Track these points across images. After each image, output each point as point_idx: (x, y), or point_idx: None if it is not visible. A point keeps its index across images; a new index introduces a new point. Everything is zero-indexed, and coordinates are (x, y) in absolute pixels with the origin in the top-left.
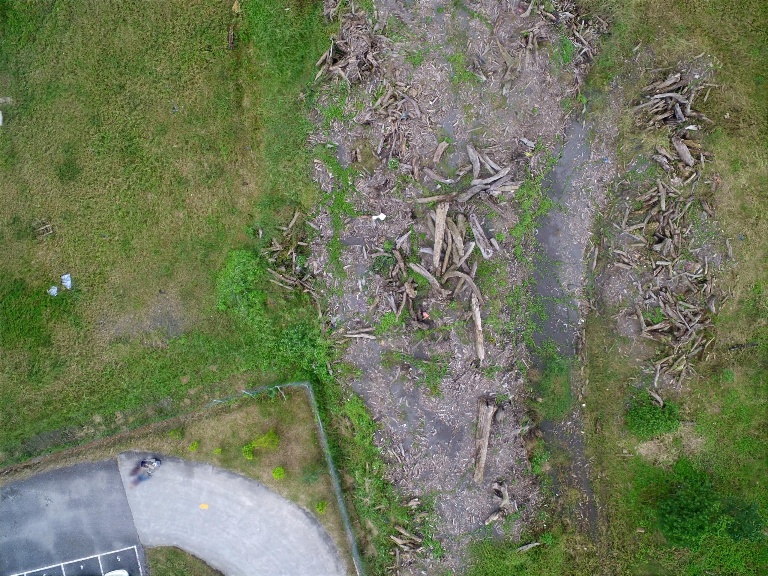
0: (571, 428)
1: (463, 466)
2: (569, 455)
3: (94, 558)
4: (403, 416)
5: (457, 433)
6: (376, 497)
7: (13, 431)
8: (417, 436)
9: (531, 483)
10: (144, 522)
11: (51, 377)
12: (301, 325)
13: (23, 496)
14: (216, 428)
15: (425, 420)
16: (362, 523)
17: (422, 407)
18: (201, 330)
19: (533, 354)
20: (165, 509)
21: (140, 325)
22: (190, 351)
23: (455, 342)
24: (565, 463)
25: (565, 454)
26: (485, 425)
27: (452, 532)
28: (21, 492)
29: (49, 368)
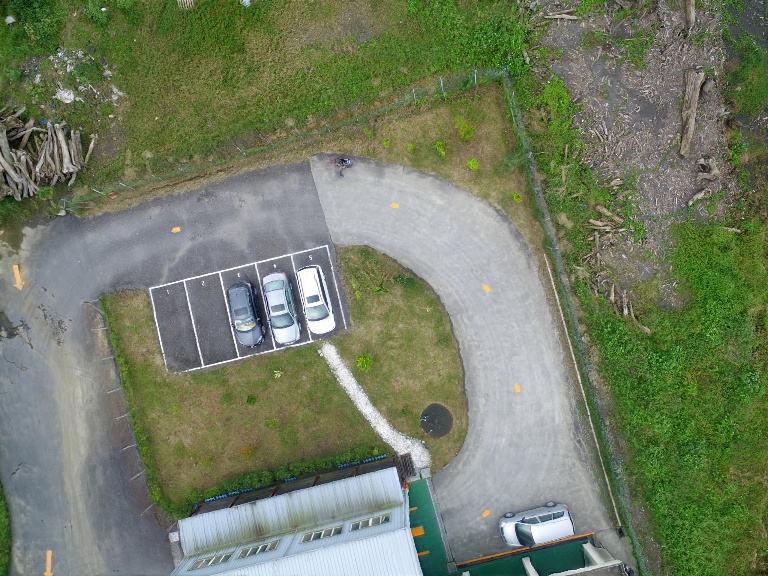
0: (767, 123)
1: (668, 142)
2: (766, 150)
3: (287, 257)
4: (605, 95)
5: (661, 110)
6: (573, 184)
7: (209, 134)
8: (620, 114)
9: (730, 173)
10: (336, 221)
11: (246, 82)
12: (497, 17)
13: (218, 197)
14: (407, 129)
15: (628, 98)
16: (555, 218)
17: (625, 85)
18: (392, 34)
19: (729, 47)
20: (356, 209)
21: (331, 32)
22: (382, 53)
23: (664, 10)
24: (763, 156)
25: (762, 148)
26: (694, 95)
27: (654, 213)
28: (216, 194)
29: (244, 73)
